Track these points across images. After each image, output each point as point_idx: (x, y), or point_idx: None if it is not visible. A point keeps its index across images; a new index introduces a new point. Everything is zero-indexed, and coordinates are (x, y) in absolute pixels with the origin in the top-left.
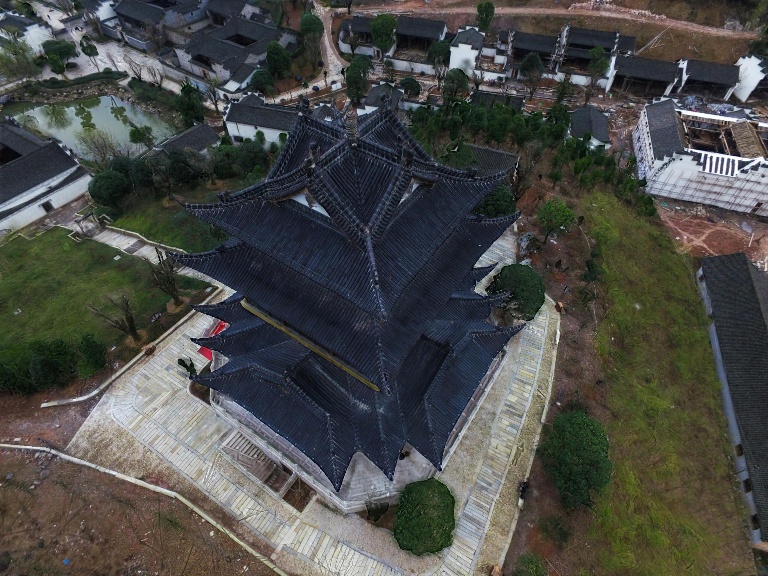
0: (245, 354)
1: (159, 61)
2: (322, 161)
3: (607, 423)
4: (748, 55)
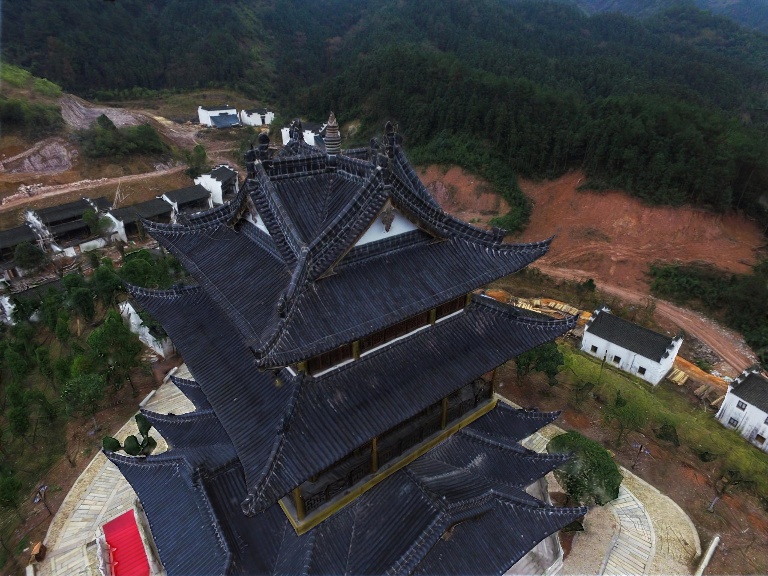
0: None
1: None
2: None
3: None
4: (198, 176)
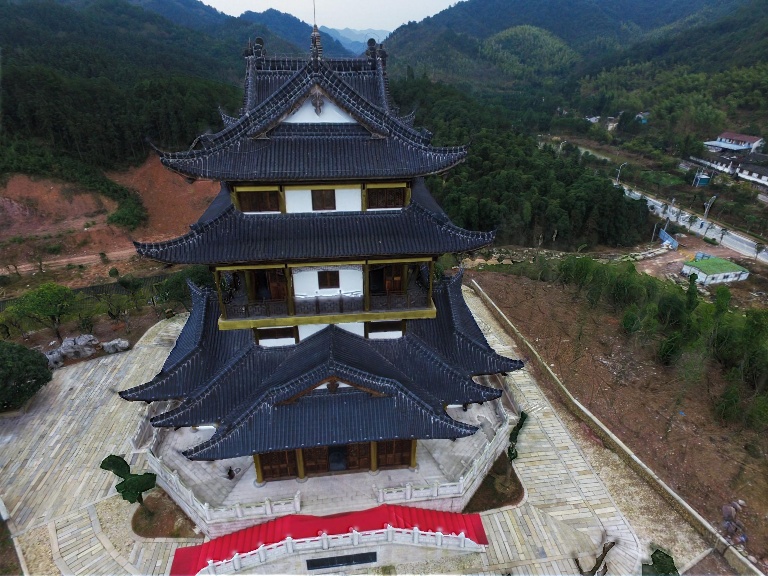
0: (454, 364)
1: None
2: None
3: None
4: None
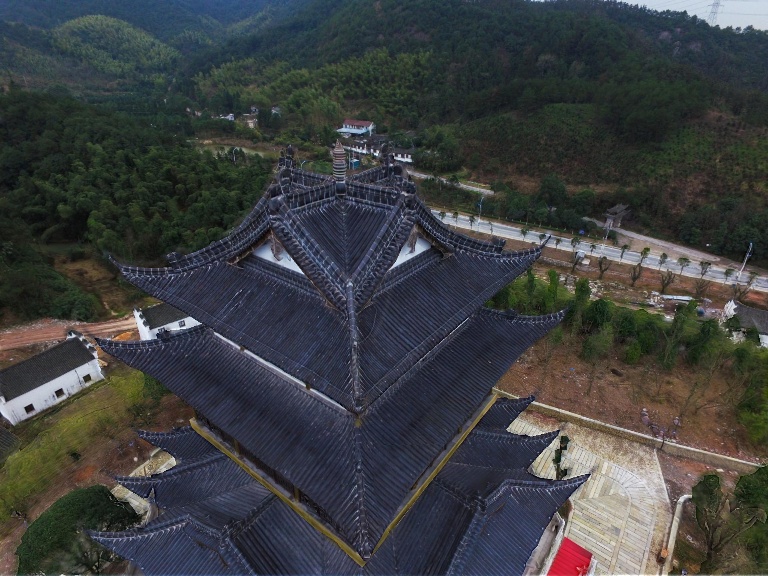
0: (490, 429)
1: None
2: None
3: None
4: None
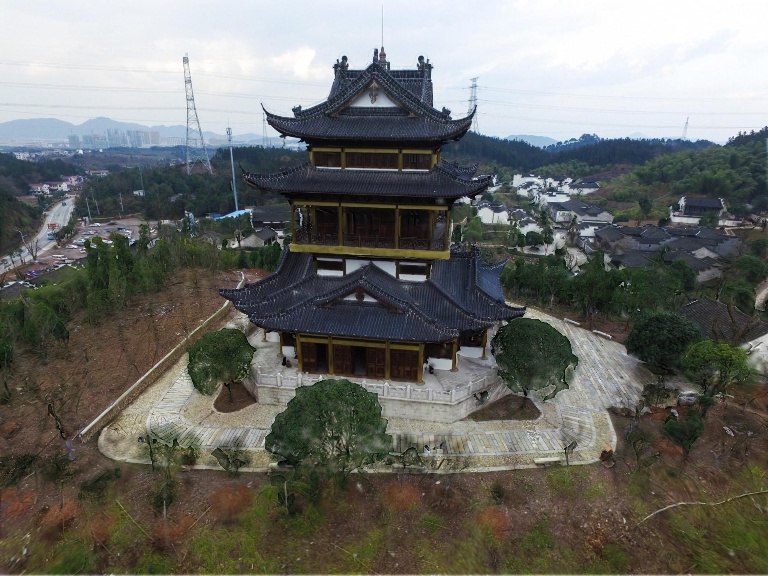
0: None
1: (587, 258)
2: (348, 72)
3: (464, 574)
4: None
